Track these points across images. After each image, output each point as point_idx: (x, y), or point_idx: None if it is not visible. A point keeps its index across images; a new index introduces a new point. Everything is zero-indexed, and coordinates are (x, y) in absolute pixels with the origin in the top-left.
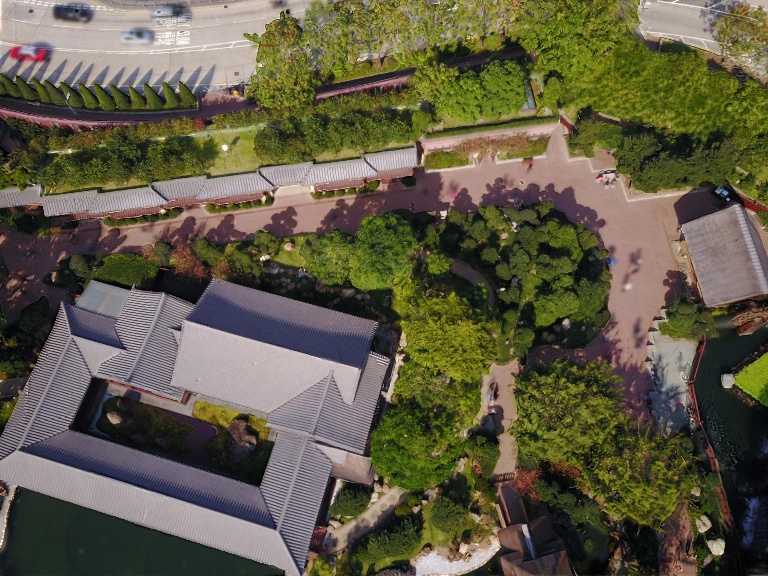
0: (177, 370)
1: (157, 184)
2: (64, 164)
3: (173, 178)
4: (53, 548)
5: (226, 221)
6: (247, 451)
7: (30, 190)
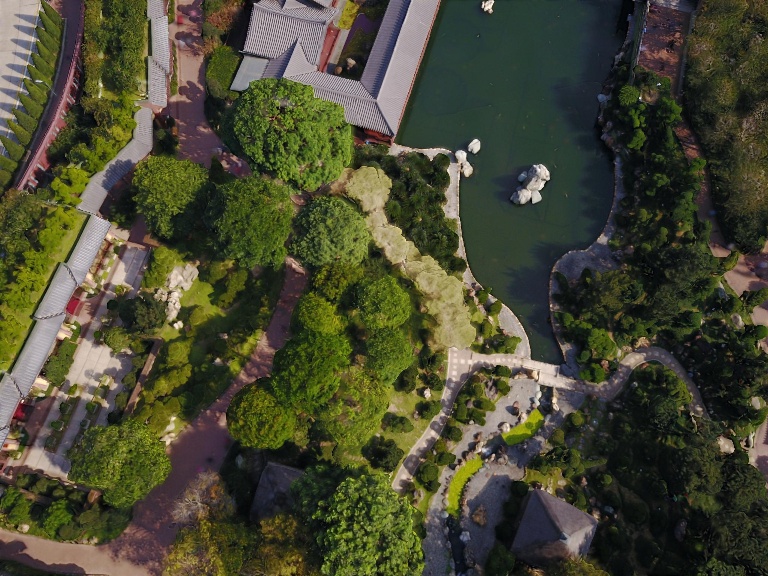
0: None
1: (149, 16)
2: (119, 70)
3: (145, 1)
4: (446, 122)
5: (183, 10)
6: None
7: (138, 114)
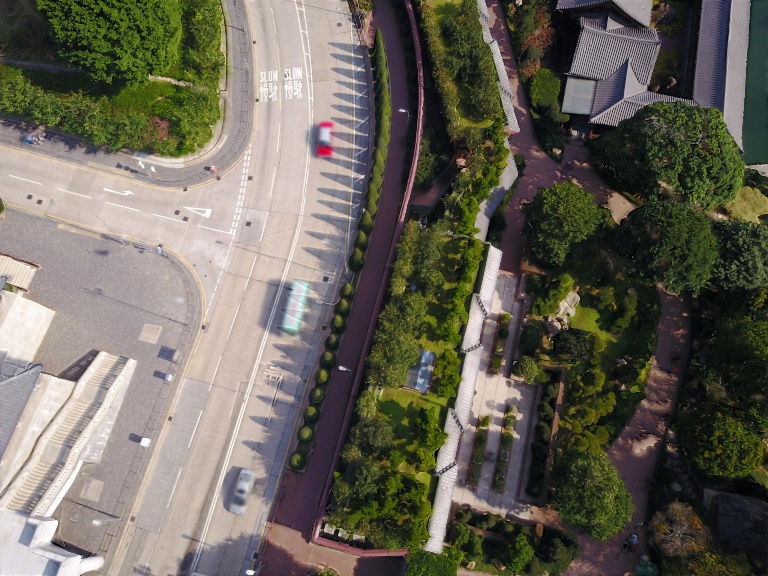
0: (640, 19)
1: None
2: None
3: None
4: (761, 137)
5: None
6: (672, 6)
7: None
